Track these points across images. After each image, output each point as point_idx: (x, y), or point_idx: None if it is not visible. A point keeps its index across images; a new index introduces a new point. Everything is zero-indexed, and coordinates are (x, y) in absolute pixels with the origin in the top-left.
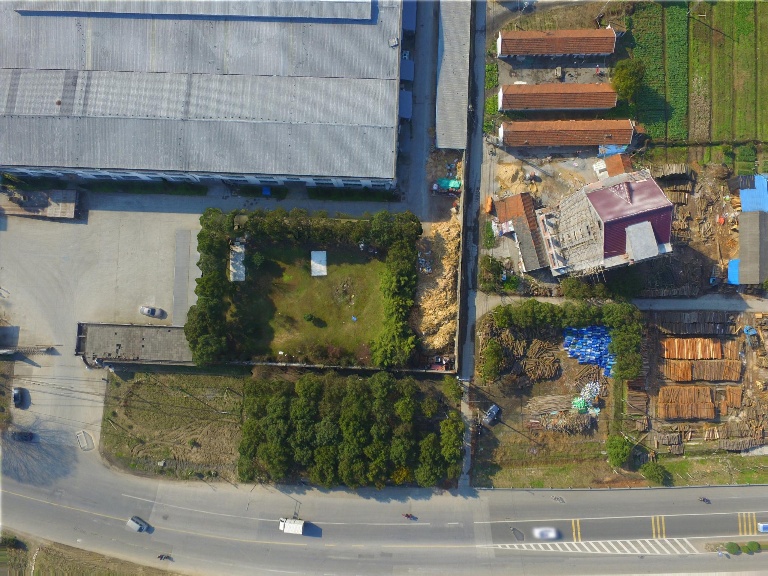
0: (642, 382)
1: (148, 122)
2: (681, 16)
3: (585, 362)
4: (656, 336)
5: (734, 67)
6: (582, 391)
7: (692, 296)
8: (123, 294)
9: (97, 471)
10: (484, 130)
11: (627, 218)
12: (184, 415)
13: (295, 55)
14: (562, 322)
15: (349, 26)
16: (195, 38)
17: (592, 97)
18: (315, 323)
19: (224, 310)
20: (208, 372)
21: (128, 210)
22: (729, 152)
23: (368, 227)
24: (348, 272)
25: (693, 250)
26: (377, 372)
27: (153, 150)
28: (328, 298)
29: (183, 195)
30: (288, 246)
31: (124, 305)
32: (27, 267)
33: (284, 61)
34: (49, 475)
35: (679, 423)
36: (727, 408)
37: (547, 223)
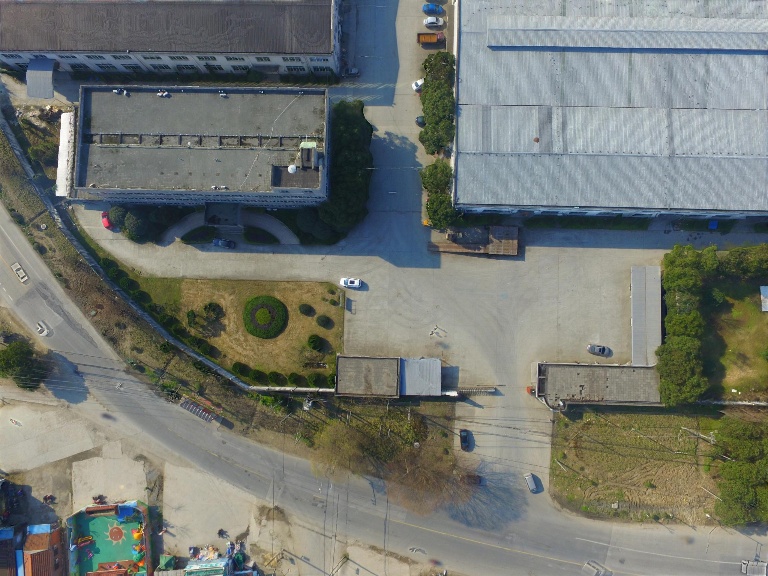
0: None
1: (633, 159)
2: None
3: None
4: None
5: None
6: None
7: None
8: (565, 332)
9: (549, 514)
10: None
11: None
12: (639, 456)
13: None
14: None
15: None
16: (674, 72)
17: None
18: None
19: None
20: (661, 411)
21: (567, 246)
22: None
23: None
24: None
25: None
26: None
27: (636, 187)
28: None
29: (623, 230)
30: (736, 281)
31: (567, 343)
32: (464, 305)
33: (767, 95)
34: (499, 519)
35: None
36: None
37: None
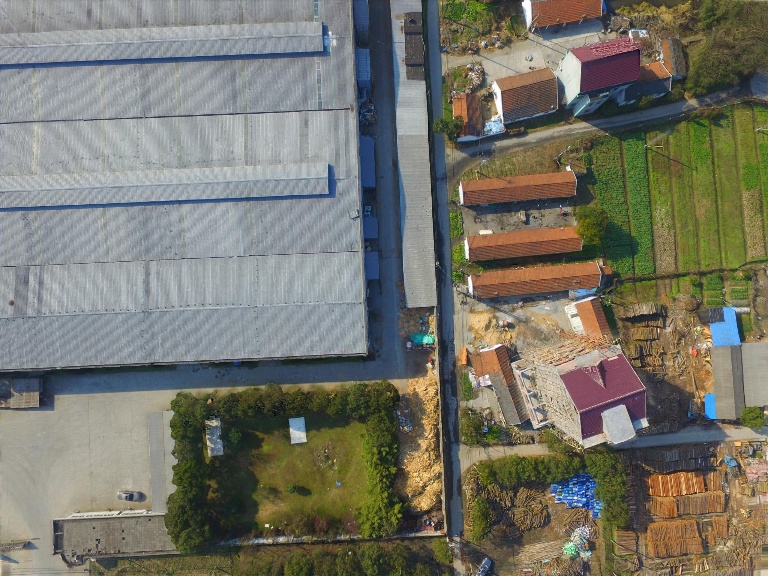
0: (630, 522)
1: (108, 316)
2: (639, 149)
3: (573, 507)
4: (640, 473)
5: (695, 196)
6: (572, 536)
7: (672, 431)
8: (98, 479)
9: None
10: (453, 280)
11: (602, 405)
12: None
13: (254, 234)
14: (547, 478)
15: (307, 201)
16: (149, 224)
17: (558, 243)
18: (299, 492)
19: (204, 496)
20: (194, 553)
21: (96, 392)
22: (696, 283)
23: (344, 404)
24: (328, 437)
25: (669, 384)
26: (366, 542)
27: (116, 344)
28: (310, 465)
29: (152, 371)
30: (265, 415)
31: (100, 491)
32: None
33: (244, 241)
34: None
35: (669, 558)
36: (714, 538)
37: (524, 376)
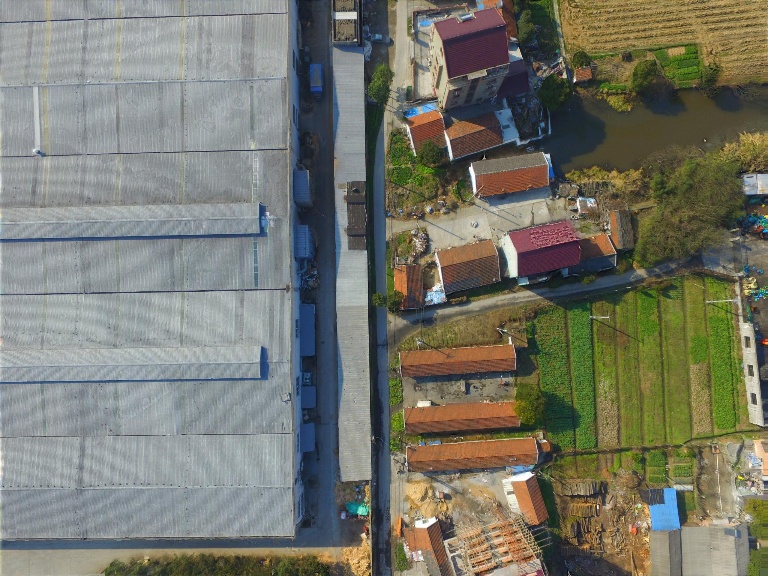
0: None
1: (42, 492)
2: (584, 320)
3: None
4: None
5: (640, 369)
6: None
7: None
8: None
9: None
10: (391, 449)
11: None
12: None
13: (188, 413)
14: None
15: (240, 382)
16: (85, 401)
17: (495, 420)
18: None
19: None
20: None
21: (37, 548)
22: None
23: None
24: None
25: (607, 562)
26: None
27: (50, 519)
28: None
29: None
30: None
31: None
32: None
33: (177, 420)
34: None
35: None
36: None
37: (456, 555)
